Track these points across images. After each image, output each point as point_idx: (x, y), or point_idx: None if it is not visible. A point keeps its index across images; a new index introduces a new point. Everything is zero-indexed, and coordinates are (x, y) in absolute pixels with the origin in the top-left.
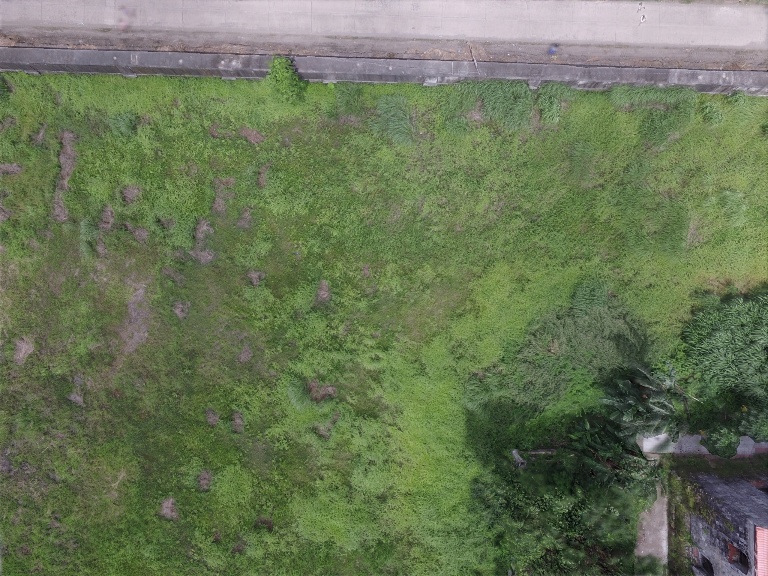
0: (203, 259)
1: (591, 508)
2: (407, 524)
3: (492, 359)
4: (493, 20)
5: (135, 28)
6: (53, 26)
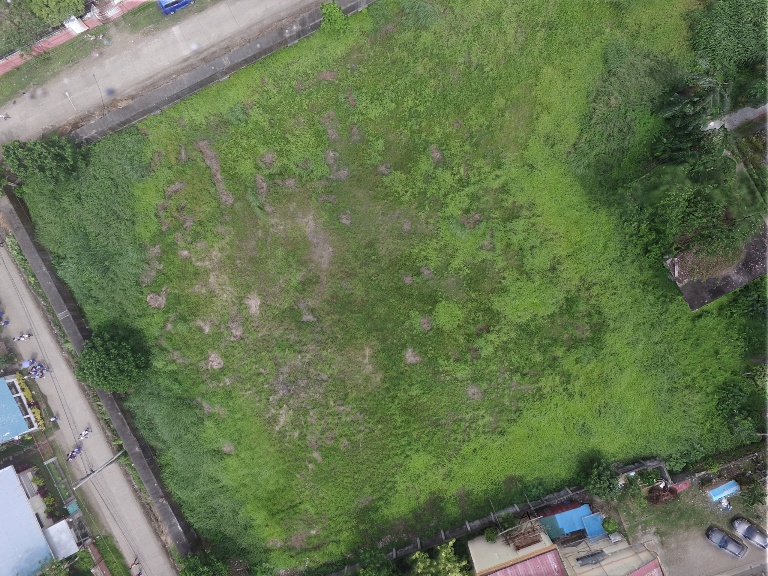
0: (342, 176)
1: (697, 187)
2: (578, 276)
3: (575, 135)
4: None
5: (207, 47)
6: (149, 76)
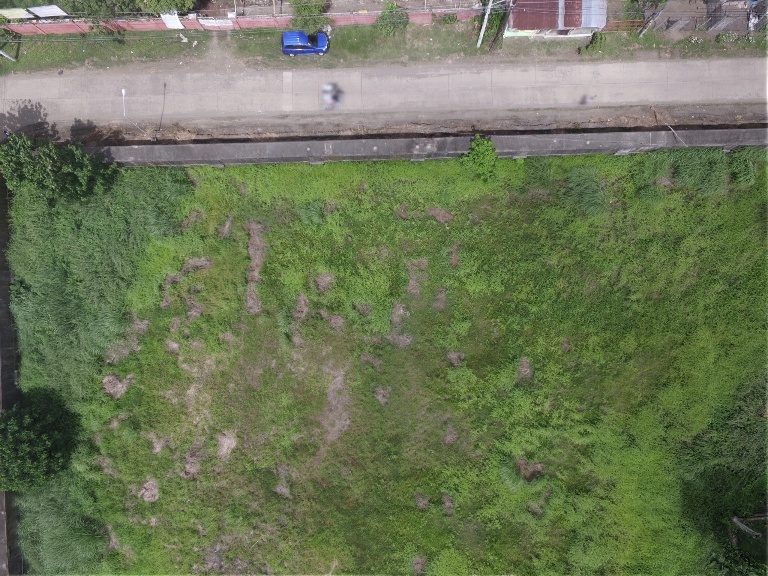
0: (402, 343)
1: None
2: None
3: (701, 426)
4: (675, 83)
5: (314, 113)
6: (230, 116)
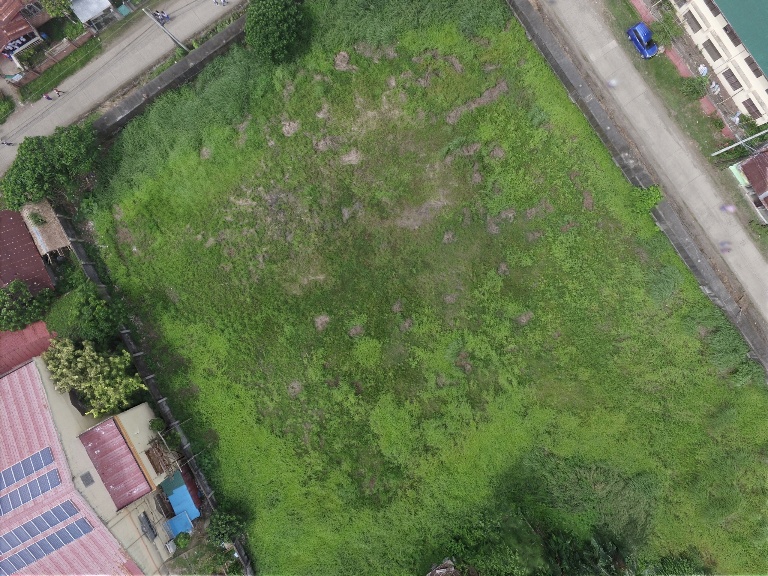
0: (490, 228)
1: None
2: (424, 475)
3: (562, 453)
4: None
5: (601, 77)
6: (564, 24)
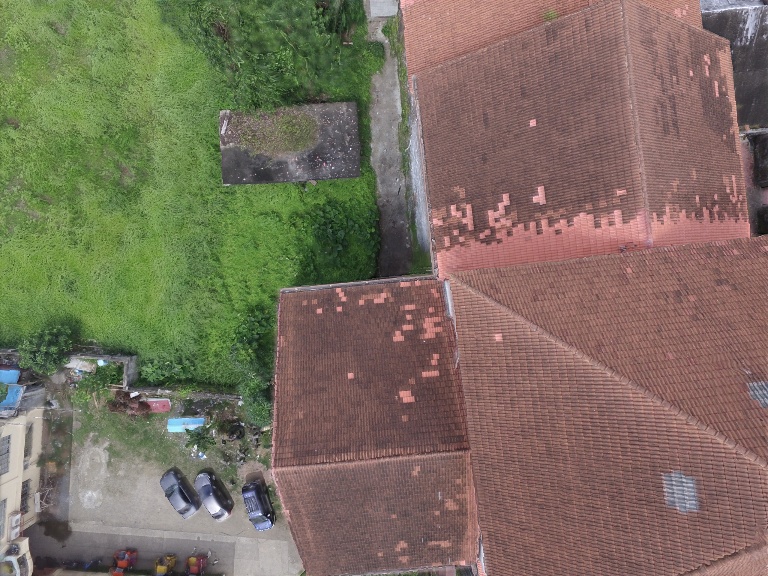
0: None
1: None
2: (147, 107)
3: None
4: None
5: None
6: None
